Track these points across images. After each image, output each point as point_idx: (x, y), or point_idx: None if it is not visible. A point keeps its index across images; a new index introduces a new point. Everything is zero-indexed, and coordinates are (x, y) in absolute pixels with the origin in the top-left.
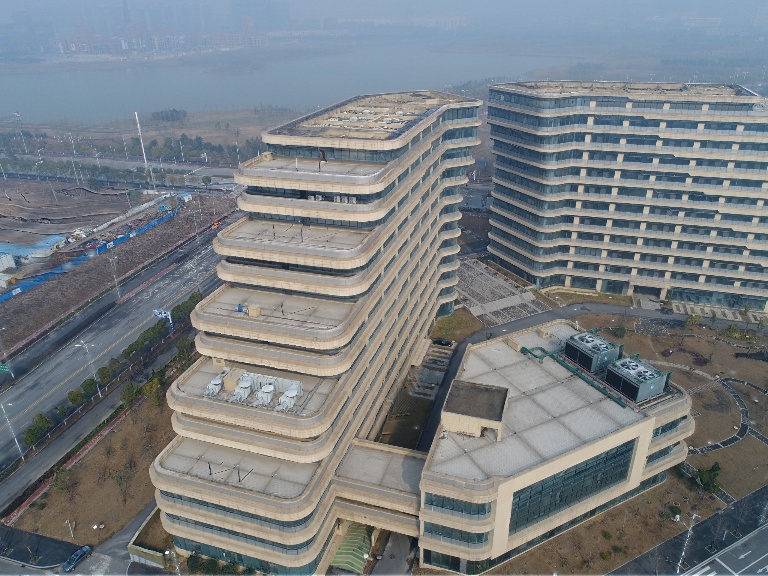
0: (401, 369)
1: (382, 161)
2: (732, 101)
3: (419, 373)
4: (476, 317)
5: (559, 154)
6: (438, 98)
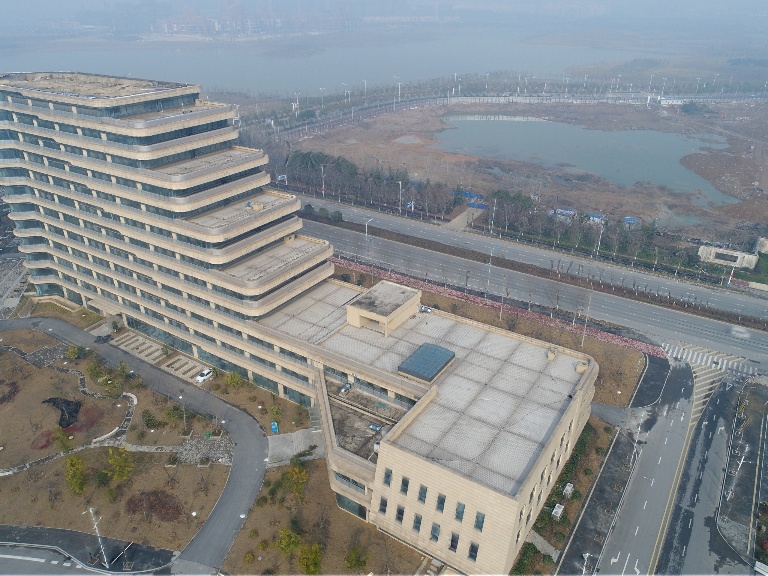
0: None
1: None
2: (82, 104)
3: None
4: None
5: None
6: None
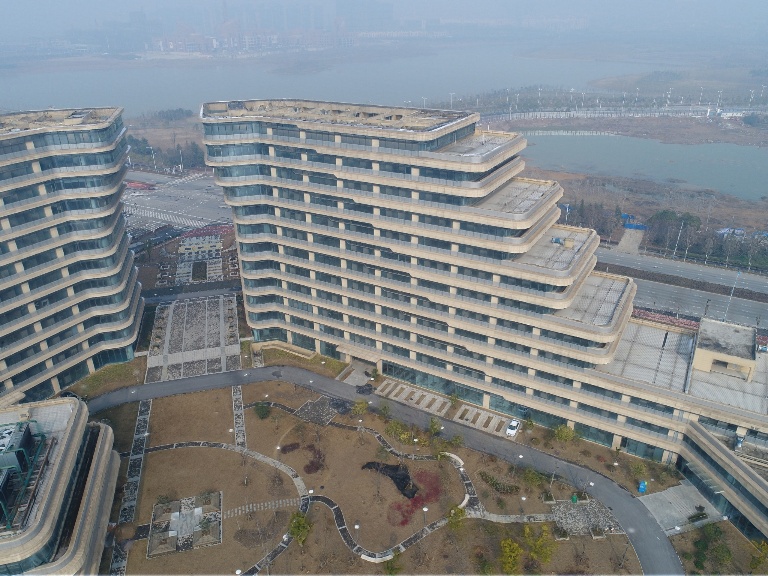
0: None
1: None
2: (397, 137)
3: None
4: (147, 369)
5: (242, 189)
6: (82, 118)
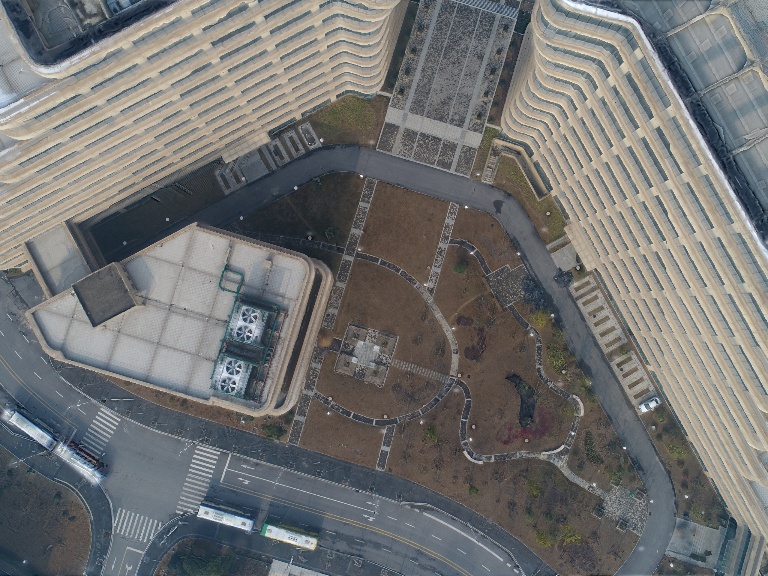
0: (197, 161)
1: None
2: (761, 265)
3: (246, 156)
4: (384, 124)
5: None
6: None
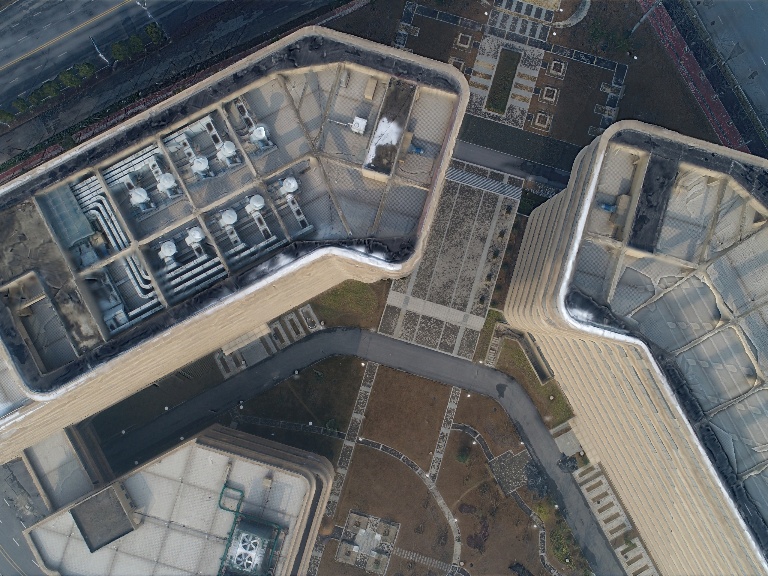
0: None
1: None
2: None
3: None
4: (385, 306)
5: None
6: (390, 175)
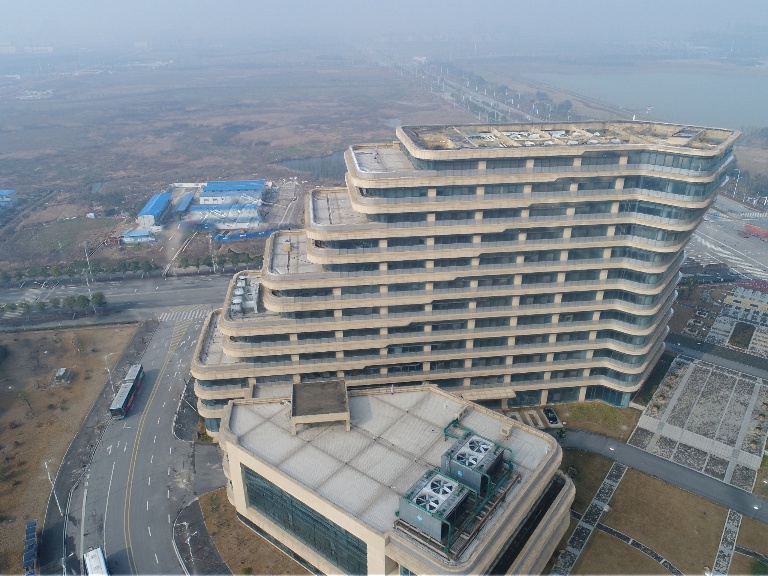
0: None
1: (419, 168)
2: None
3: None
4: (636, 427)
5: None
6: (689, 138)
